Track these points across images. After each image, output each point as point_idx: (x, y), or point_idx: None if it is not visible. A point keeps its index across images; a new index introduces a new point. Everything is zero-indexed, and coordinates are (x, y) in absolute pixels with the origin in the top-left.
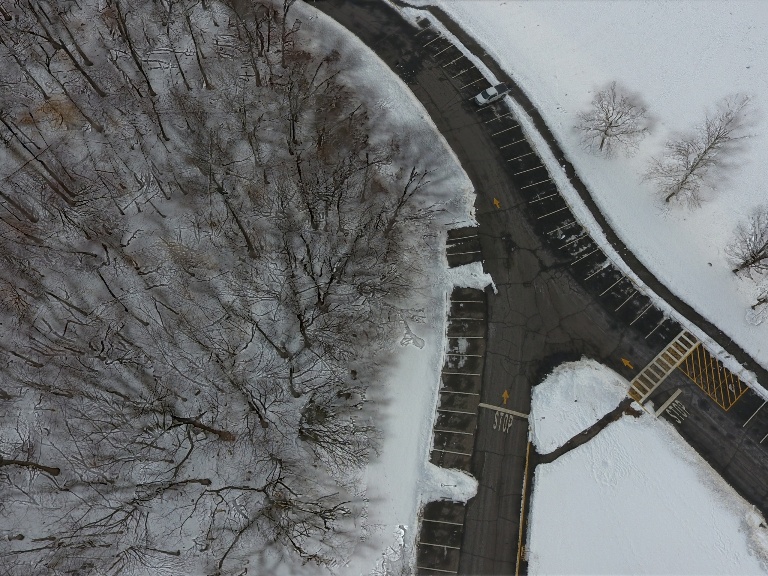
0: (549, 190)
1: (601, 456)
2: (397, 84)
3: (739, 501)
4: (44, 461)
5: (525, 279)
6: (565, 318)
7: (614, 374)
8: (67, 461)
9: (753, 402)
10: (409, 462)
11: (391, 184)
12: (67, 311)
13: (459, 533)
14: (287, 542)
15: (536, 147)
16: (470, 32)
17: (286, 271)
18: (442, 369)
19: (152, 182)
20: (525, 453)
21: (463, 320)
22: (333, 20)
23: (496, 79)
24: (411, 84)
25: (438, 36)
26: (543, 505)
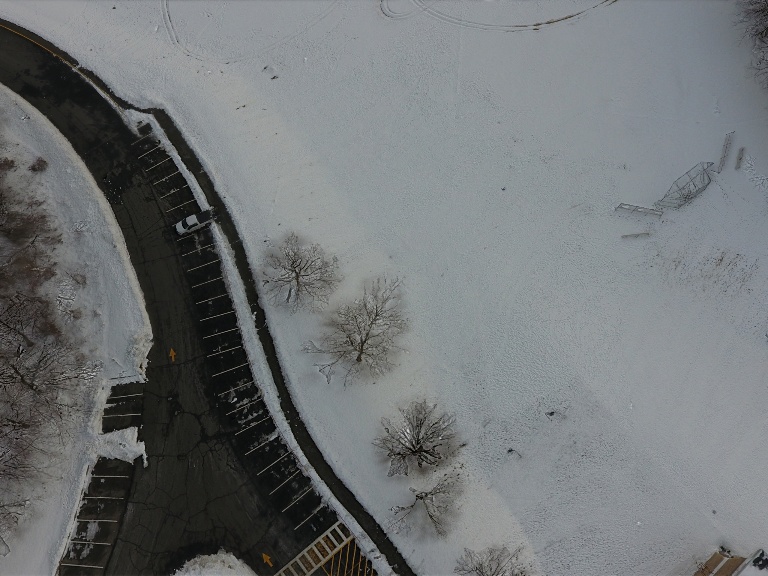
0: (233, 341)
1: None
2: (97, 204)
3: None
4: None
5: (181, 450)
6: (213, 501)
7: (249, 573)
8: None
9: None
10: None
11: (67, 325)
12: None
13: None
14: None
15: (230, 288)
16: (191, 143)
17: None
18: (61, 560)
19: None
20: None
21: (100, 499)
22: (47, 121)
23: (206, 202)
24: (114, 204)
25: (157, 146)
26: None
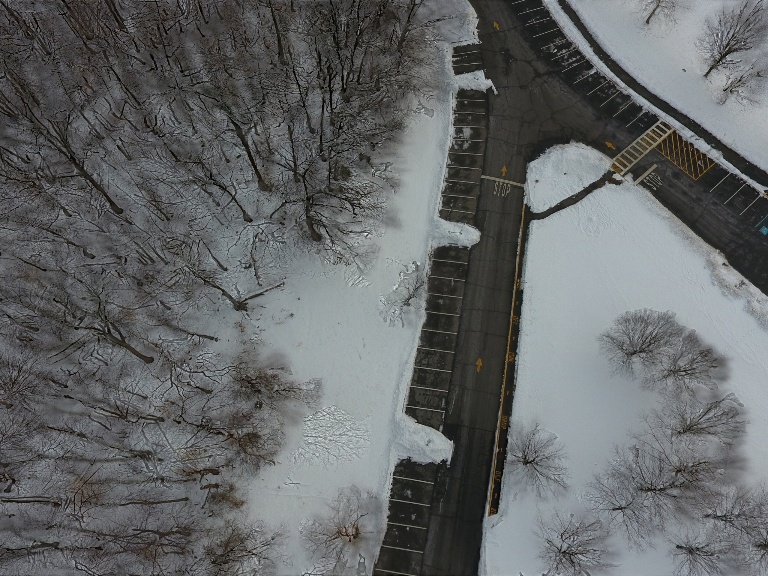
0: (543, 15)
1: (587, 214)
2: None
3: (705, 245)
4: (111, 196)
5: (522, 83)
6: (556, 112)
7: (599, 153)
8: (130, 199)
9: (719, 173)
10: (421, 217)
11: (403, 13)
12: (124, 93)
13: (464, 269)
14: (319, 251)
15: None
16: None
17: (312, 73)
18: (449, 150)
19: (192, 10)
20: (521, 212)
21: (467, 114)
22: None
23: None
24: None
25: None
26: (536, 249)
